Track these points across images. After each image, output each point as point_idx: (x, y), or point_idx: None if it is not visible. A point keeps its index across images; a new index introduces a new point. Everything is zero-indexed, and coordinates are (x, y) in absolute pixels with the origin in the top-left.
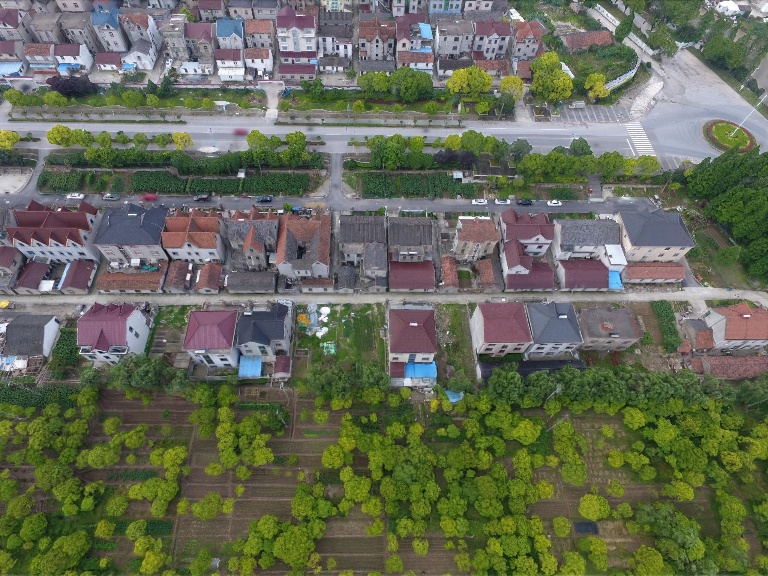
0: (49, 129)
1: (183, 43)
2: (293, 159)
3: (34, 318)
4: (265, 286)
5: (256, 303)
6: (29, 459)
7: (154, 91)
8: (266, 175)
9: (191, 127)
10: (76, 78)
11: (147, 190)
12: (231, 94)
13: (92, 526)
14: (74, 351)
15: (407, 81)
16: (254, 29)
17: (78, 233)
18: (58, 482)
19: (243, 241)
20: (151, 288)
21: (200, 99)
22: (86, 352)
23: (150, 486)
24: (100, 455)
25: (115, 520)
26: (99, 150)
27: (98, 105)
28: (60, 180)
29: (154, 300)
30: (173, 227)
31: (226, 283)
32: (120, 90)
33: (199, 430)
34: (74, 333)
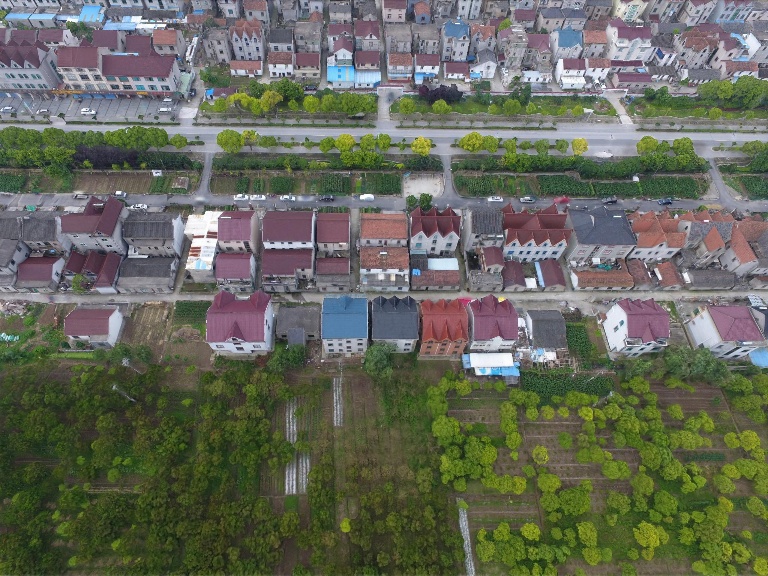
0: (437, 136)
1: (523, 53)
2: (688, 164)
3: (546, 313)
4: (727, 283)
5: (722, 299)
6: (633, 442)
7: (517, 99)
8: (654, 179)
9: (563, 133)
10: (446, 87)
11: (557, 193)
12: (580, 102)
13: (705, 503)
14: (587, 344)
15: (757, 89)
16: (592, 40)
17: (570, 234)
18: (668, 463)
19: (699, 241)
20: (627, 285)
21: (555, 106)
22: (631, 344)
23: (750, 466)
24: (694, 438)
25: (728, 497)
26: (519, 156)
27: (467, 112)
28: (478, 184)
29: (624, 296)
30: (637, 228)
31: (688, 280)
32: (487, 98)
33: (755, 415)
34: (576, 327)
